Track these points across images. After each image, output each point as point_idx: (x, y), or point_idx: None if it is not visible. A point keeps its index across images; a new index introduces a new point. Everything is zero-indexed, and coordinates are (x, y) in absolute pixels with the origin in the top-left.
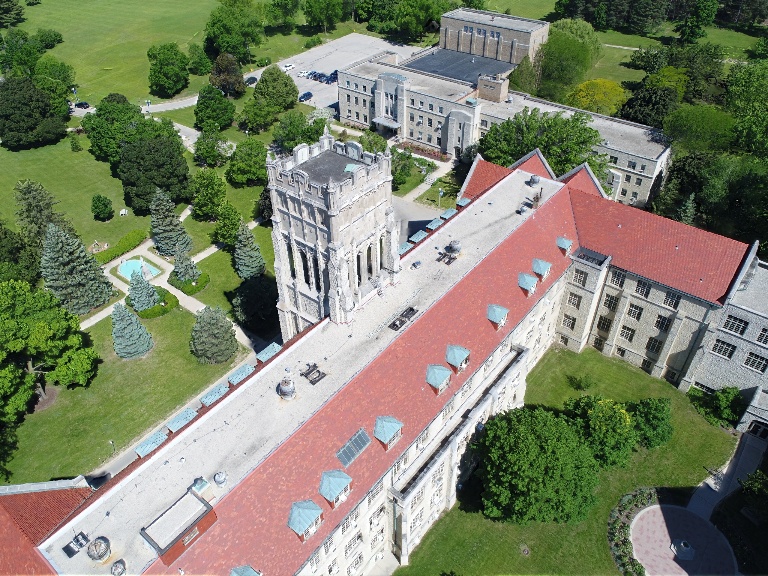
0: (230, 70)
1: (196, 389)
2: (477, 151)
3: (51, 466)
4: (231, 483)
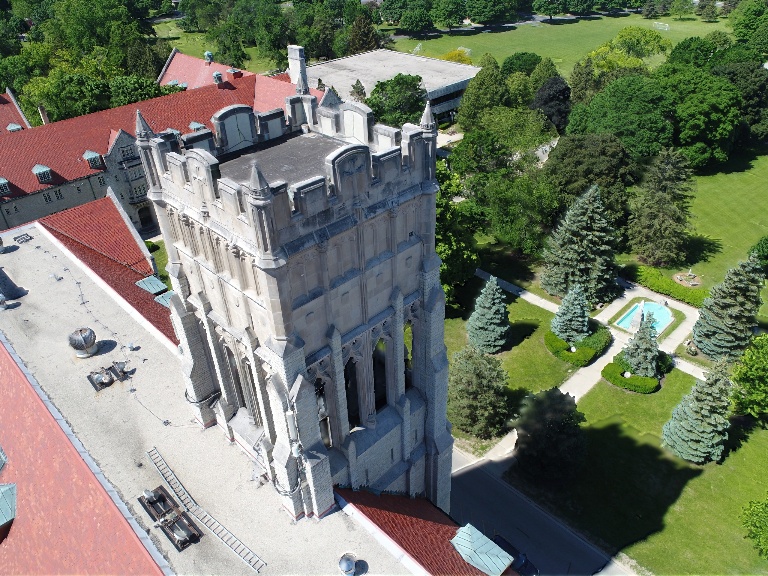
0: None
1: None
2: None
3: None
4: None
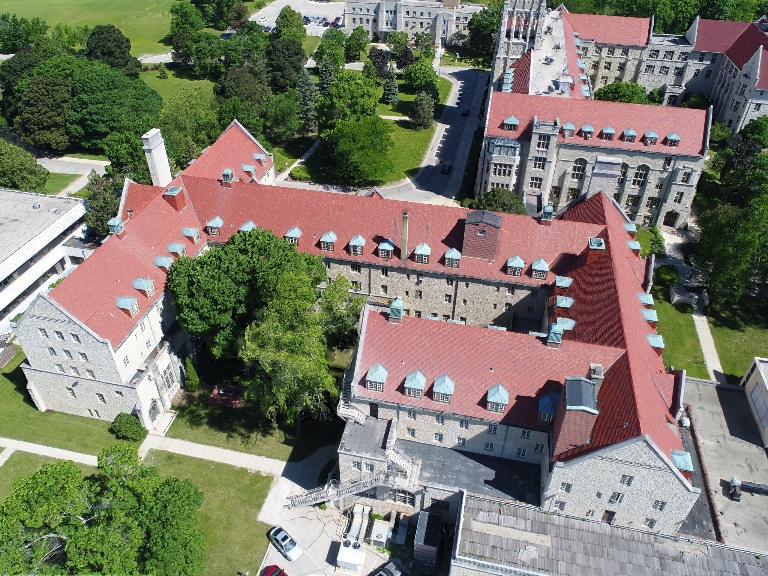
0: (246, 15)
1: (429, 137)
2: (458, 36)
3: (396, 169)
4: None
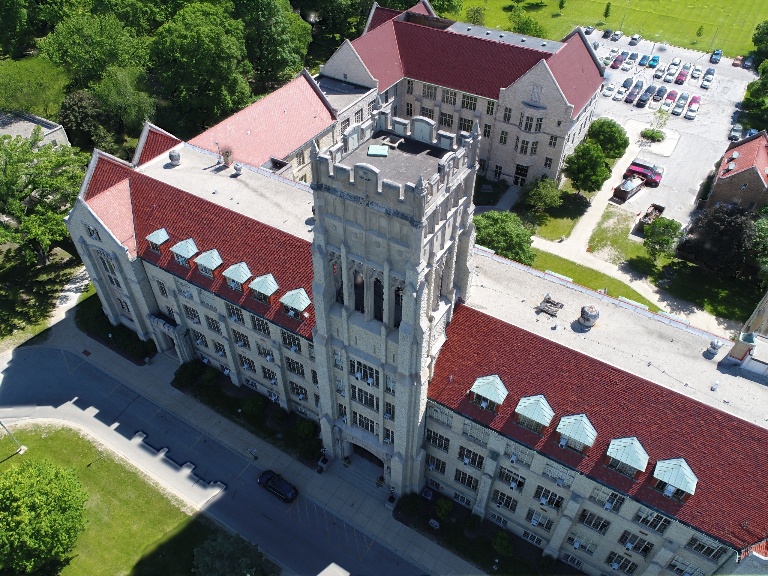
0: None
1: None
2: None
3: None
4: (709, 342)
